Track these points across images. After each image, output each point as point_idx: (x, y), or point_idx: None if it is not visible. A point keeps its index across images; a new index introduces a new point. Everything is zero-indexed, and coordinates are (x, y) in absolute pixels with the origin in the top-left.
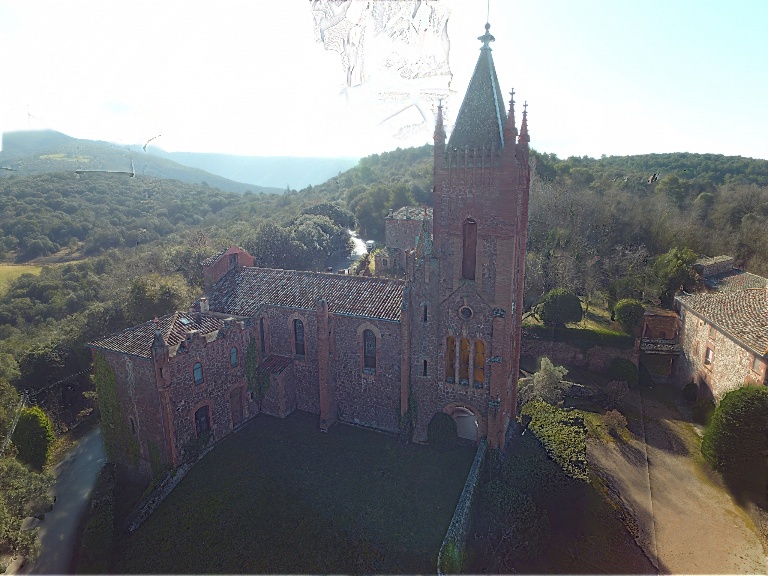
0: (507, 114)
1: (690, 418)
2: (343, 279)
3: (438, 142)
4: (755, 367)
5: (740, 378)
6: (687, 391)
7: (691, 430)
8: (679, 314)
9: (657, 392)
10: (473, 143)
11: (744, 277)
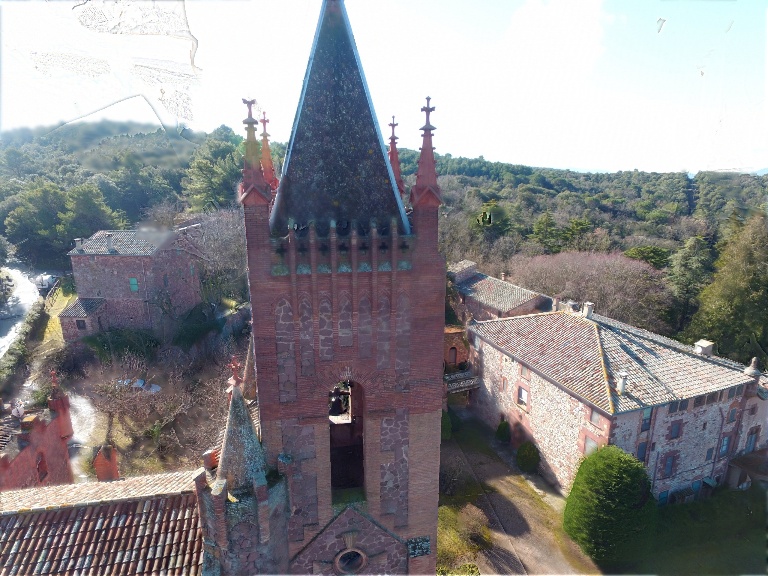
0: (259, 109)
1: (517, 468)
2: (1, 529)
3: (256, 212)
4: (593, 420)
5: (573, 428)
6: (502, 433)
7: (527, 487)
8: (473, 344)
9: (470, 436)
10: (337, 212)
11: (490, 282)
